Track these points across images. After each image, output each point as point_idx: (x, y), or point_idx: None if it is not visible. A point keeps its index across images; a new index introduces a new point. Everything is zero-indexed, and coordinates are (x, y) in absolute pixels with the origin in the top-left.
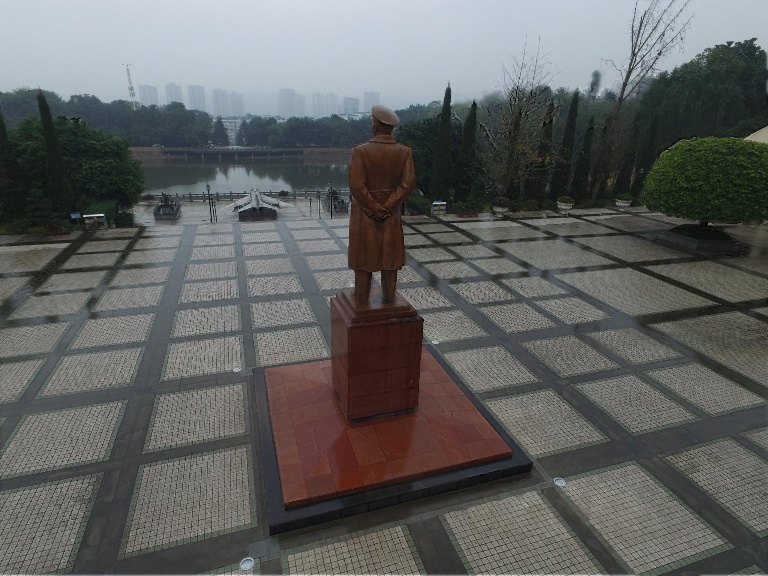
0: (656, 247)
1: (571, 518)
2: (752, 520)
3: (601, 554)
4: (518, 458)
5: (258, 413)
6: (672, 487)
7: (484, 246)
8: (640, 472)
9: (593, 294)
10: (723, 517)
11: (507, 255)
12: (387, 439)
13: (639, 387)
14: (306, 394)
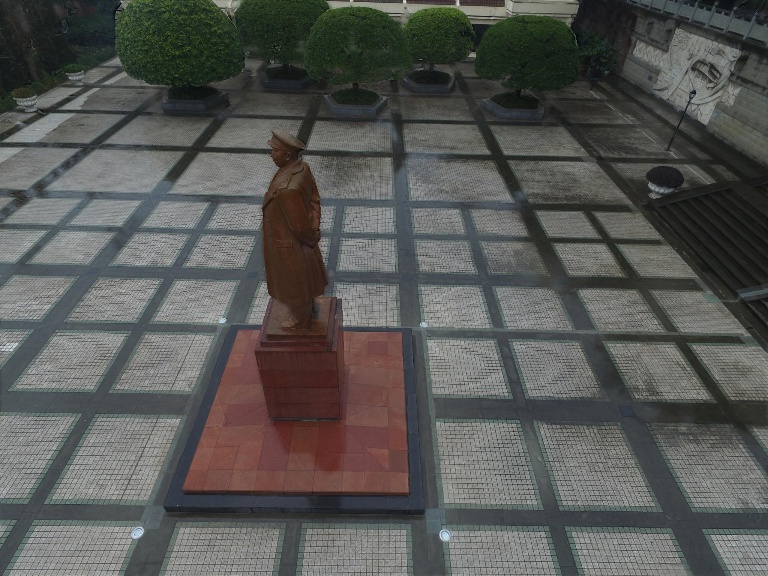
0: (180, 120)
1: (451, 334)
2: (469, 270)
3: (477, 335)
4: (405, 333)
5: (267, 507)
6: (442, 282)
7: (42, 197)
8: (428, 288)
9: (225, 193)
10: (465, 278)
11: (89, 195)
12: (367, 399)
13: (356, 243)
14: (269, 449)
